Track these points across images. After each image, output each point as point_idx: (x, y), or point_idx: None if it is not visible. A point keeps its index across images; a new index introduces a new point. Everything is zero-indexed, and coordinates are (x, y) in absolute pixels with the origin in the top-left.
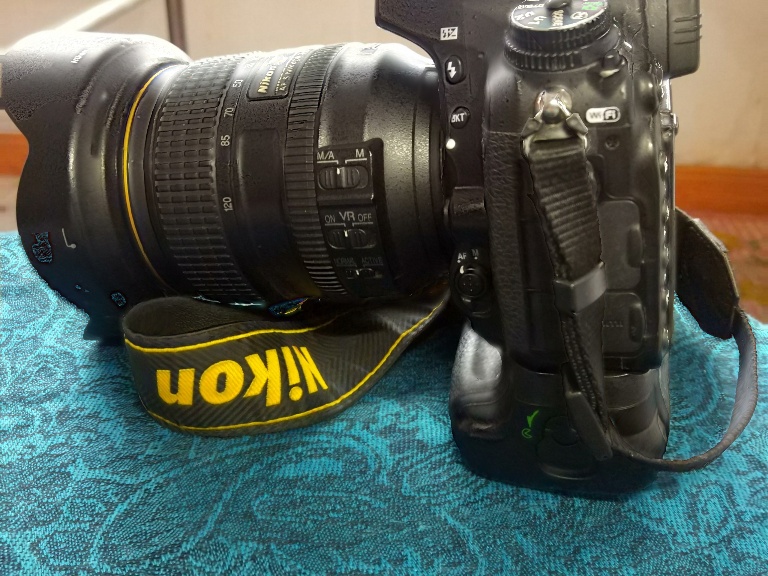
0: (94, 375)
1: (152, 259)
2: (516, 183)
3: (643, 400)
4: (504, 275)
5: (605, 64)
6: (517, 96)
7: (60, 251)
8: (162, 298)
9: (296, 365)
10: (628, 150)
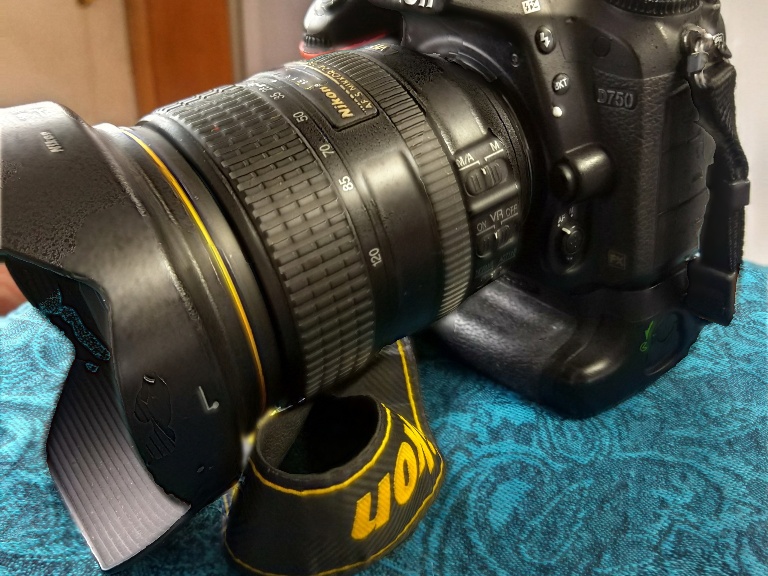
0: None
1: (268, 379)
2: (662, 120)
3: None
4: (644, 209)
5: None
6: (664, 41)
7: (192, 424)
8: (258, 432)
9: None
10: None
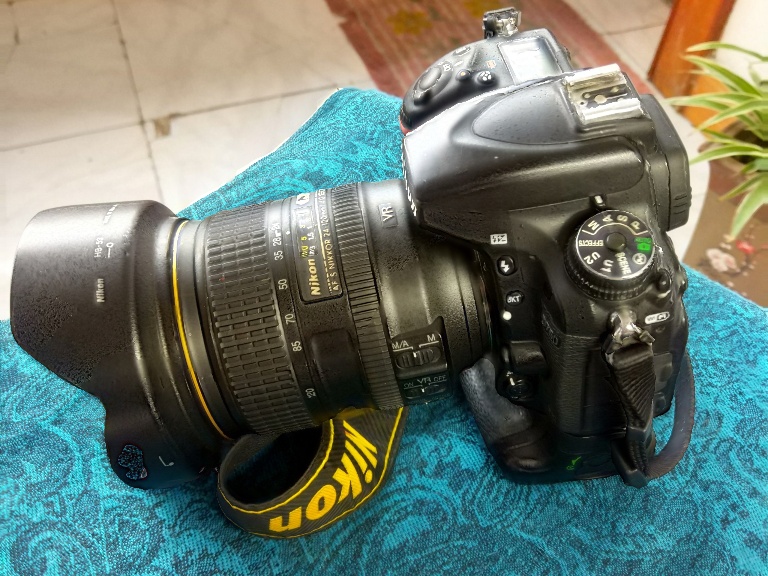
0: (172, 511)
1: (230, 435)
2: (585, 360)
3: (651, 429)
4: (567, 402)
5: (660, 288)
6: (591, 315)
7: (156, 469)
8: (233, 448)
9: (359, 453)
10: (671, 330)
